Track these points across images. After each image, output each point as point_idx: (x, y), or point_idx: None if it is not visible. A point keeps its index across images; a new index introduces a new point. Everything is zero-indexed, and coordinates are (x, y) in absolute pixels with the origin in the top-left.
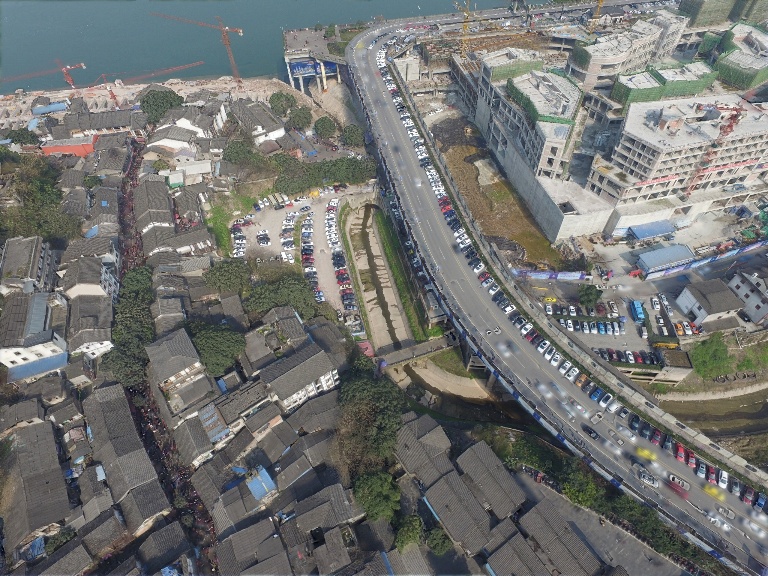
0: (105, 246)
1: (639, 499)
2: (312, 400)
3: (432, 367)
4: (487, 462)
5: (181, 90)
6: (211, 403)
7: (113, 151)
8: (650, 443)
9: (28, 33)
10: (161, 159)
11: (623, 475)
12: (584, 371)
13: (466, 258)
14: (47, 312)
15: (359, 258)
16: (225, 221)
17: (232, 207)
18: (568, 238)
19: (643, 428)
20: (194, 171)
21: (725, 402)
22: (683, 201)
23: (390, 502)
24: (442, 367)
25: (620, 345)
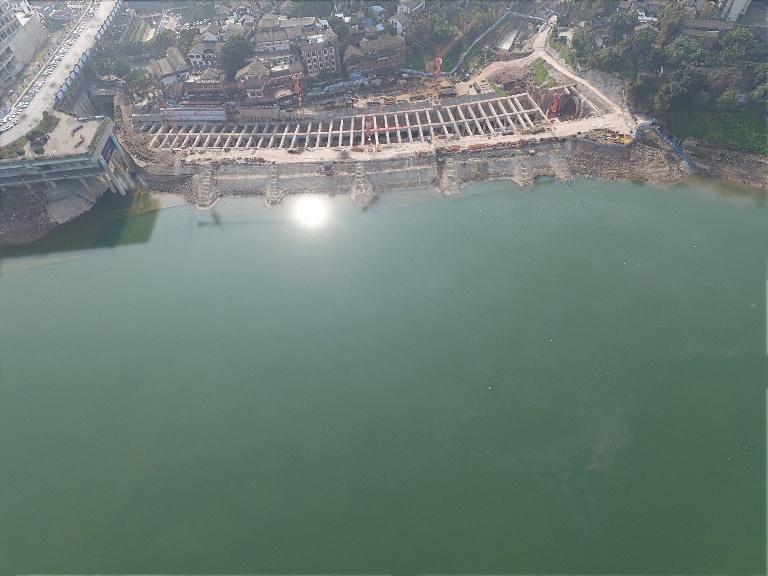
0: None
1: None
2: None
3: None
4: None
5: (252, 152)
6: None
7: None
8: None
9: (613, 367)
10: None
11: None
12: None
13: None
14: None
15: None
16: None
17: None
18: None
19: None
20: None
21: None
22: None
23: None
24: None
25: None
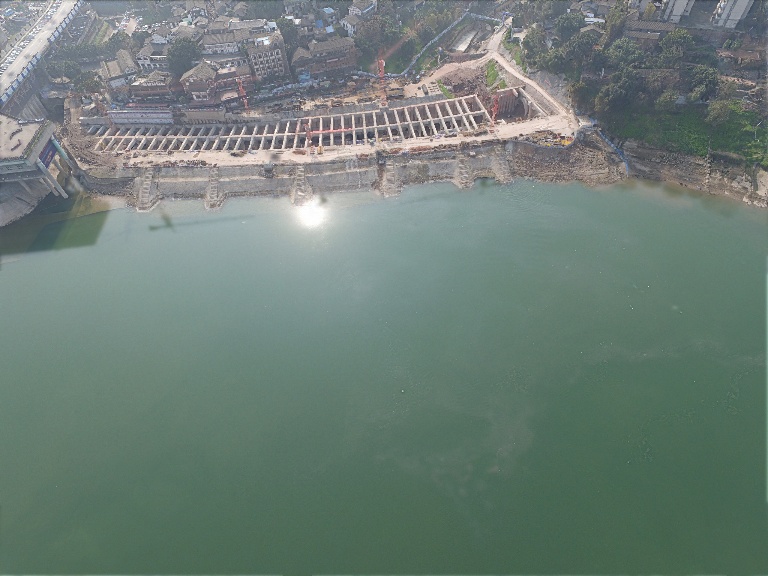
0: None
1: None
2: None
3: None
4: None
5: (195, 155)
6: None
7: None
8: None
9: (528, 370)
10: None
11: None
12: None
13: (58, 8)
14: None
15: None
16: None
17: None
18: None
19: None
20: None
21: None
22: None
23: None
24: None
25: None
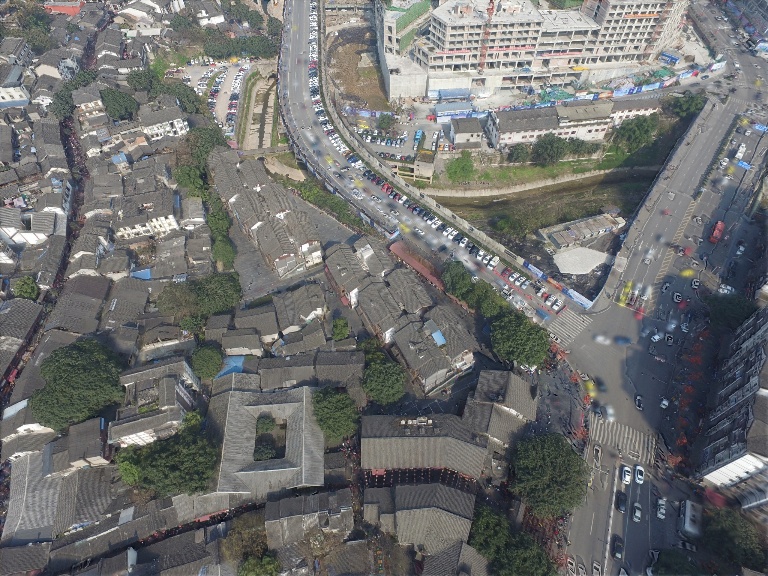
0: (68, 55)
1: (342, 198)
2: (168, 136)
3: (277, 163)
4: (254, 165)
5: None
6: (105, 127)
7: (93, 13)
8: (371, 183)
9: None
10: (127, 23)
11: (344, 193)
12: (352, 150)
13: (310, 92)
14: (21, 77)
15: (257, 107)
16: (163, 68)
17: (170, 60)
18: (398, 97)
19: (370, 175)
20: (148, 33)
21: (464, 199)
22: (479, 74)
23: (192, 178)
24: (281, 162)
25: (397, 152)
